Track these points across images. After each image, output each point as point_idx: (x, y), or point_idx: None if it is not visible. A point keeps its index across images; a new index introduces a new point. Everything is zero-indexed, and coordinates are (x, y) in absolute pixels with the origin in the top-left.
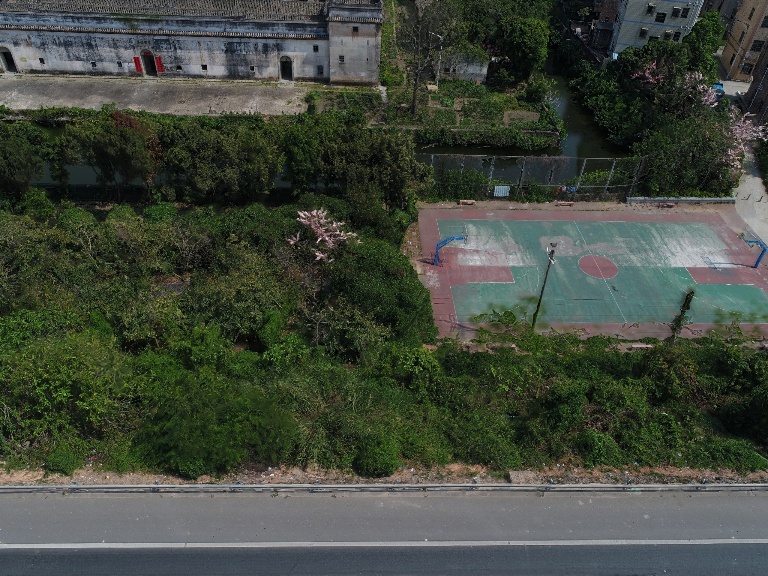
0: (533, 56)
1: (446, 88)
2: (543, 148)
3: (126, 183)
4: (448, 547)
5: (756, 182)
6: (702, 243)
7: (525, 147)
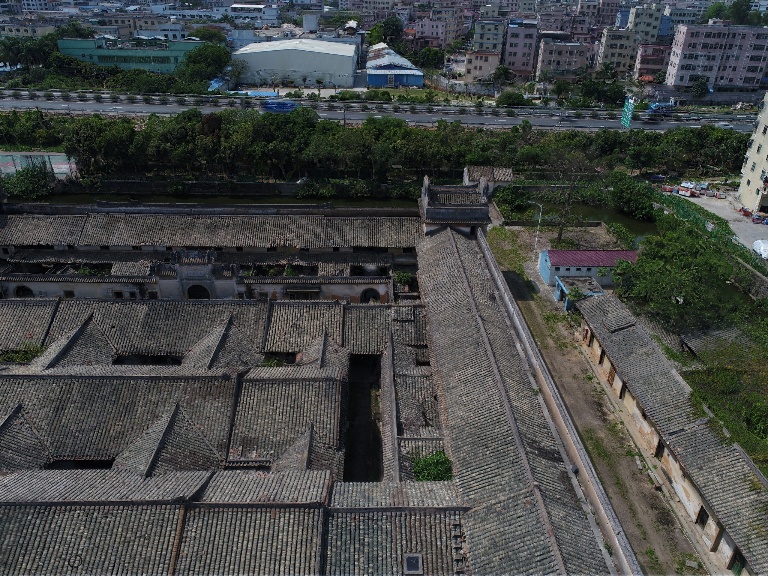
0: None
1: None
2: None
3: (229, 182)
4: None
5: None
6: None
7: None
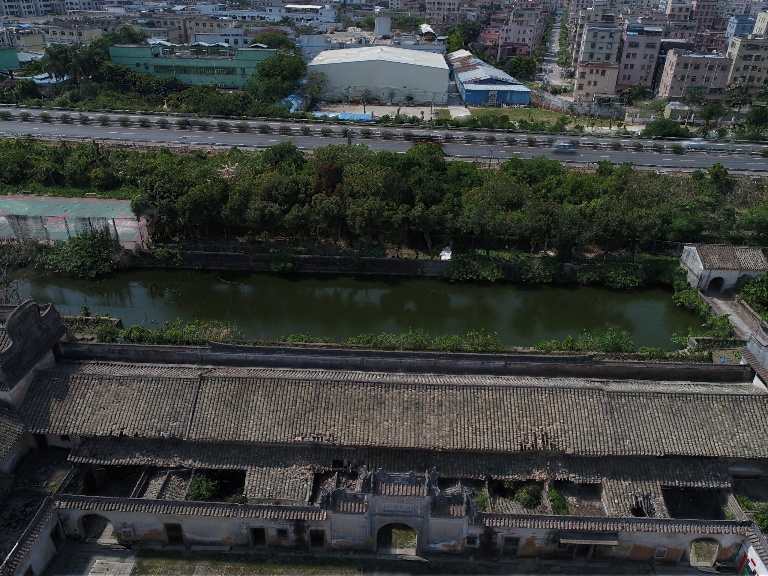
0: None
1: None
2: None
3: None
4: (225, 143)
5: None
6: None
7: None
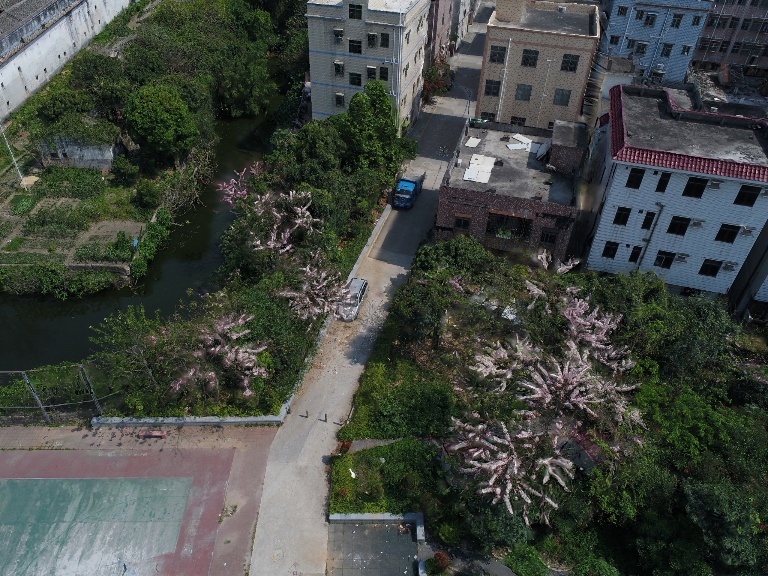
0: (153, 139)
1: (52, 180)
2: (95, 293)
3: None
4: None
5: (350, 375)
6: (135, 537)
7: (56, 295)
